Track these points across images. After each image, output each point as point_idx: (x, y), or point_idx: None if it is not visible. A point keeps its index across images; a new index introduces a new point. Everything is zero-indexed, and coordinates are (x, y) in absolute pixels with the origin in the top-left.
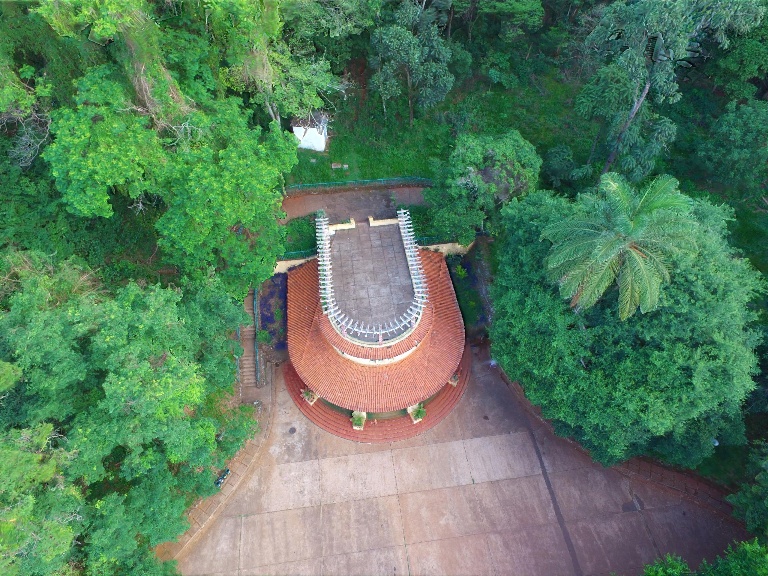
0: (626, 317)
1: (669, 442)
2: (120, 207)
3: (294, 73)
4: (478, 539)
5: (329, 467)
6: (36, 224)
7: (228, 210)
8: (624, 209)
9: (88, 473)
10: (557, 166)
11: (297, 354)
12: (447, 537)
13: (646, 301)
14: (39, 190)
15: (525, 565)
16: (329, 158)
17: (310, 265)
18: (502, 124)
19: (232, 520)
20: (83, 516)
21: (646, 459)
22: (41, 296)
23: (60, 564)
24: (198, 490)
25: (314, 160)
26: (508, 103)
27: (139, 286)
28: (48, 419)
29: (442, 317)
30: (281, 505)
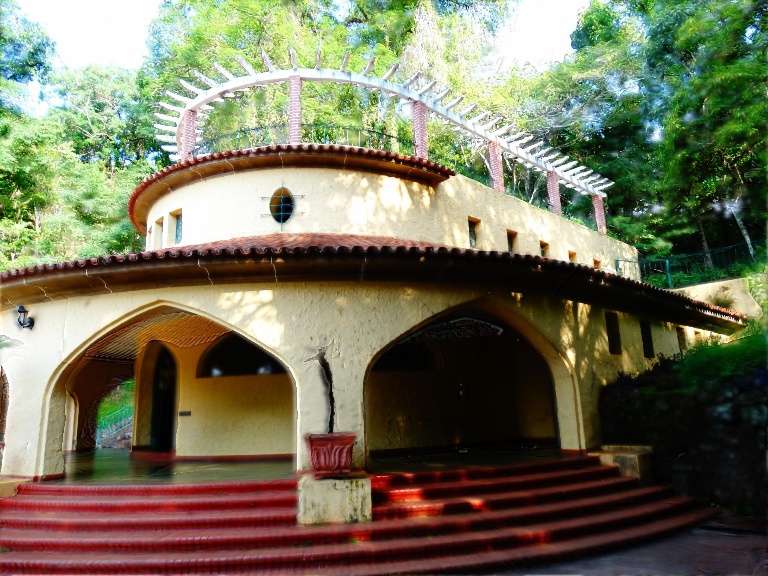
0: None
1: None
2: None
3: None
4: None
5: None
6: None
7: None
8: None
9: None
10: None
11: None
12: None
13: None
14: None
15: None
16: None
17: None
18: None
19: None
20: None
21: None
22: None
23: None
24: None
25: None
26: None
27: None
28: None
29: None
30: None
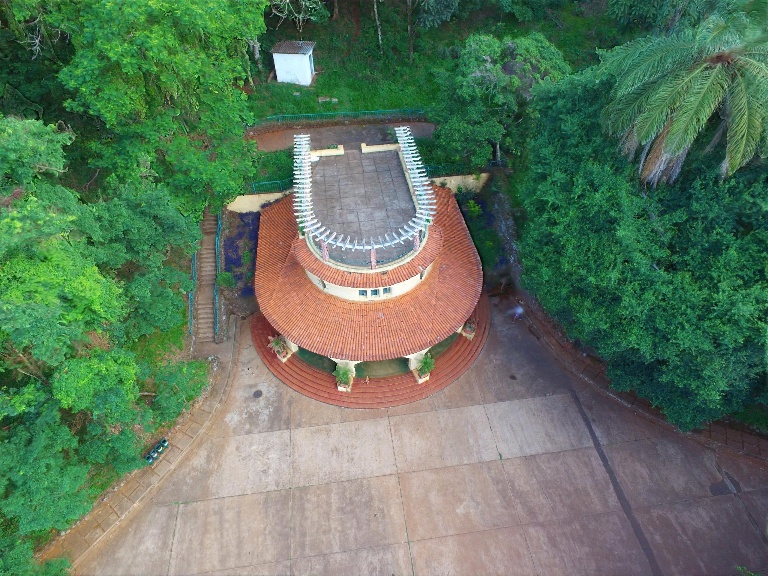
0: (737, 167)
1: None
2: (54, 123)
3: None
4: (512, 534)
5: (304, 439)
6: None
7: (156, 41)
8: None
9: None
10: None
11: (266, 294)
12: (468, 531)
13: None
14: None
15: (582, 570)
16: (315, 92)
17: (288, 199)
18: None
19: (165, 509)
20: None
21: (734, 425)
22: None
23: None
24: (114, 461)
25: (298, 93)
26: None
27: None
28: None
29: (453, 251)
30: (235, 488)
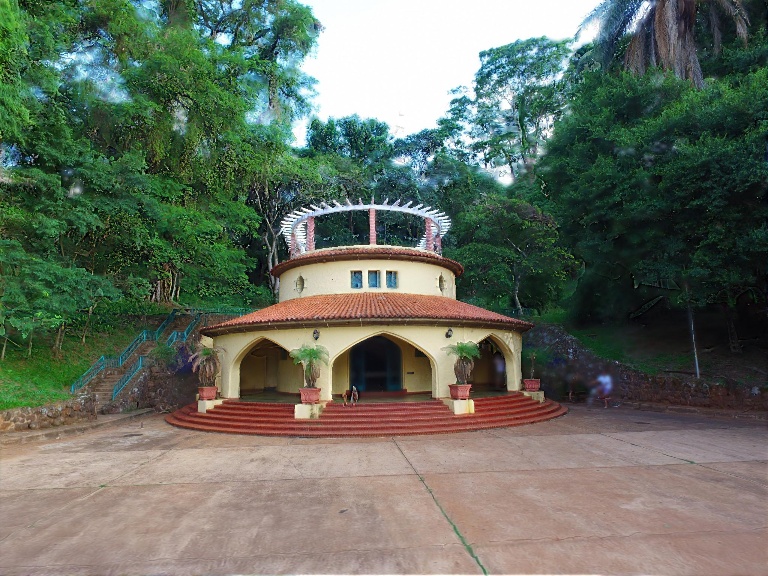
0: None
1: None
2: None
3: None
4: None
5: (193, 453)
6: None
7: None
8: None
9: None
10: None
11: None
12: (692, 527)
13: None
14: None
15: None
16: None
17: None
18: None
19: None
20: None
21: None
22: None
23: None
24: None
25: None
26: None
27: None
28: None
29: None
30: None
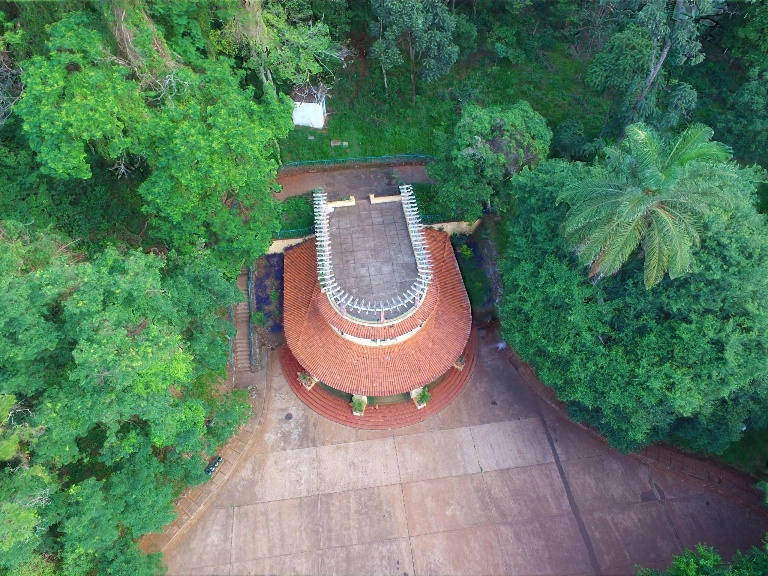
0: (652, 285)
1: (693, 426)
2: (107, 182)
3: (290, 35)
4: (487, 531)
5: (327, 455)
6: (15, 196)
7: (217, 171)
8: (653, 161)
9: (60, 454)
10: (567, 141)
11: (294, 336)
12: (454, 528)
13: (676, 264)
14: (19, 161)
15: (538, 558)
16: (328, 135)
17: (308, 244)
18: (508, 101)
19: (224, 511)
20: (58, 504)
21: (666, 446)
22: (11, 262)
23: (32, 555)
24: (187, 478)
25: (312, 137)
26: (515, 79)
27: (118, 251)
28: (15, 394)
29: (447, 297)
30: (276, 495)
